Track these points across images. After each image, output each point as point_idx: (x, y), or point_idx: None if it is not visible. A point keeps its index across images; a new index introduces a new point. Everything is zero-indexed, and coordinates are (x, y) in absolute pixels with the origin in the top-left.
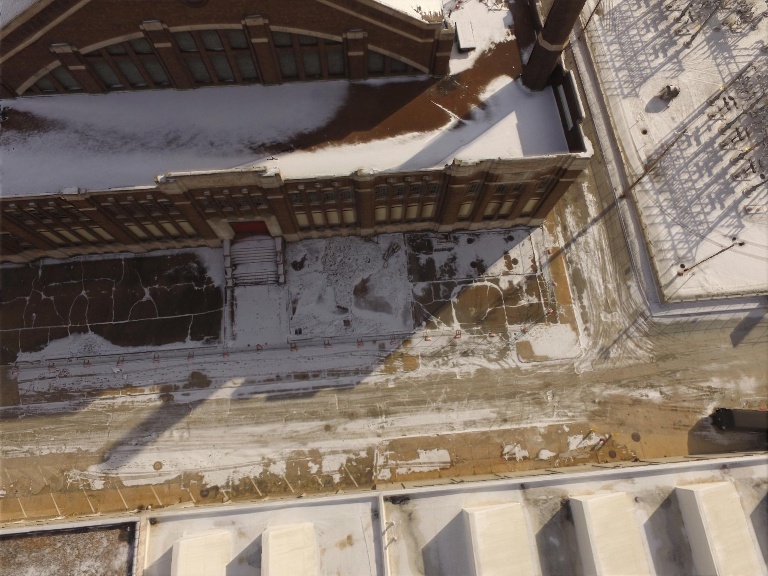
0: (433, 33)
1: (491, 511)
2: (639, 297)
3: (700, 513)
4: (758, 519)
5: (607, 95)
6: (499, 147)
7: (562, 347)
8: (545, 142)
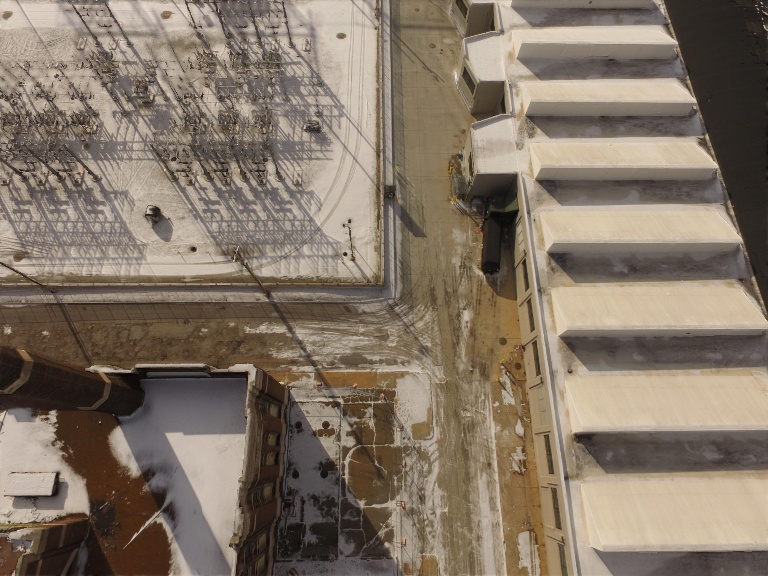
0: (31, 565)
1: (596, 522)
2: (375, 305)
3: (584, 330)
4: (577, 278)
5: (137, 275)
6: (213, 463)
7: (420, 392)
8: (216, 403)
